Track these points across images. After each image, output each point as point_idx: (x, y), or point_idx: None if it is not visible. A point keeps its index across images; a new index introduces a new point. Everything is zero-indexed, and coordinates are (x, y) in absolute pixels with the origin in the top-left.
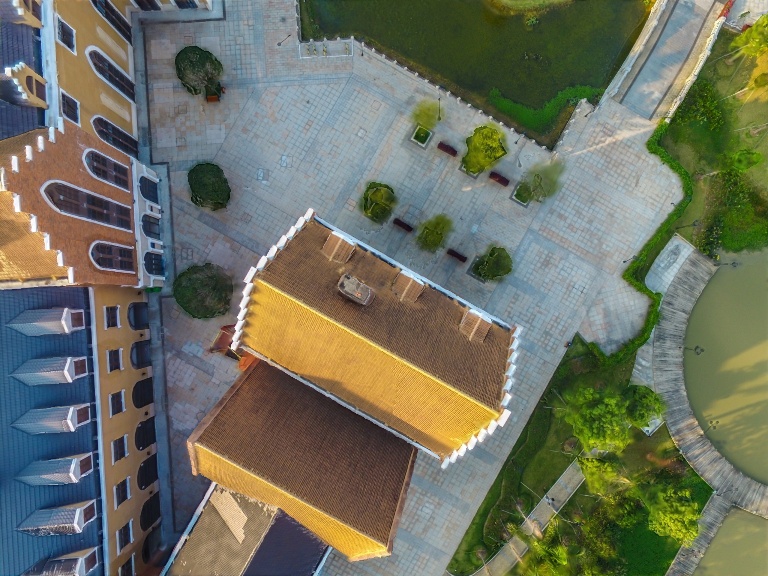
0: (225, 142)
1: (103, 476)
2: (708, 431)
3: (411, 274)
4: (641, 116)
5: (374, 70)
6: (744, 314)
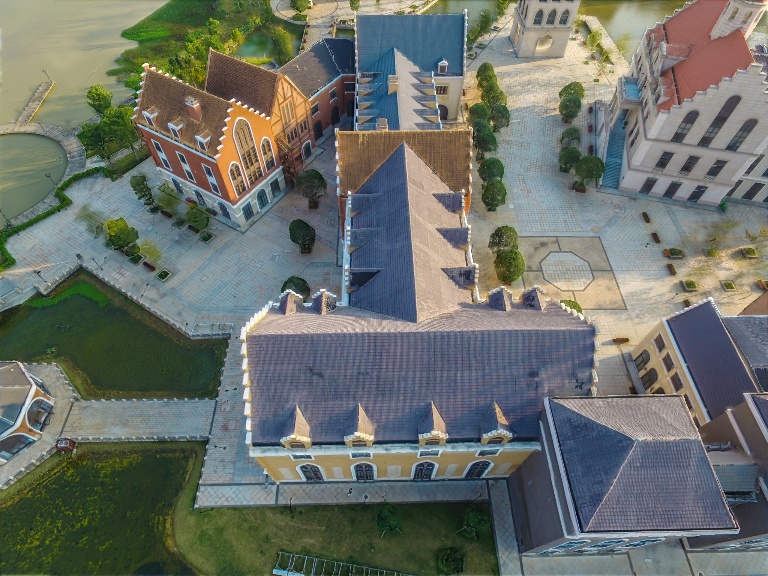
0: (297, 276)
1: (355, 107)
2: (64, 156)
3: (171, 125)
4: (8, 280)
5: (182, 315)
6: (8, 204)
